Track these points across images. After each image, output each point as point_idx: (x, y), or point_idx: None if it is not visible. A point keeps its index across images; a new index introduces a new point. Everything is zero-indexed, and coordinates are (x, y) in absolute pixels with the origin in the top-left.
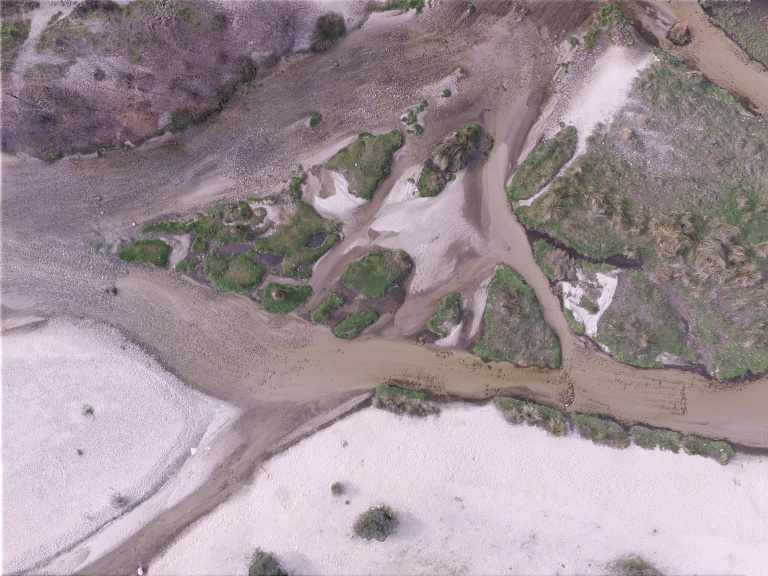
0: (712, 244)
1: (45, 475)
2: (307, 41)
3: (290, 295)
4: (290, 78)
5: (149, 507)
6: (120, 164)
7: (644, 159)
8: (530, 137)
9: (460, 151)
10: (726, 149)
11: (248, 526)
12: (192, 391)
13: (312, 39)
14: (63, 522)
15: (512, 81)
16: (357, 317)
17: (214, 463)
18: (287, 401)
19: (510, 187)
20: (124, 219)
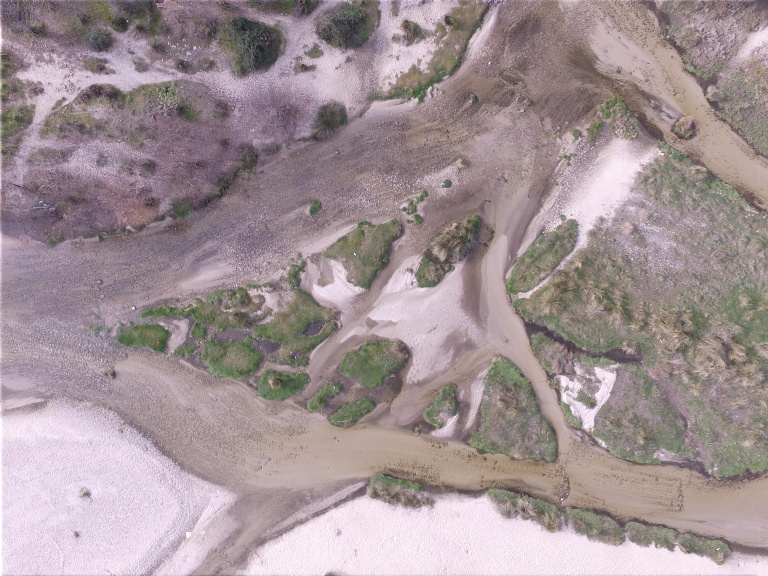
0: (713, 344)
1: (42, 556)
2: (308, 129)
3: (287, 383)
4: (291, 165)
5: None
6: (121, 248)
7: (645, 254)
8: (530, 229)
9: (459, 245)
10: (729, 246)
11: None
12: (188, 475)
13: (313, 128)
14: None
15: (513, 172)
16: (353, 406)
17: (209, 547)
18: (282, 488)
19: (509, 279)
20: (124, 303)
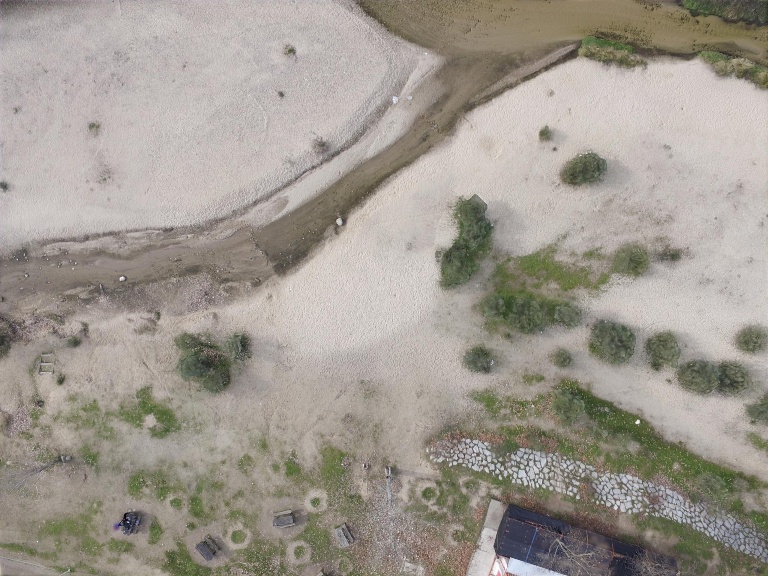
0: None
1: (245, 117)
2: None
3: None
4: None
5: (349, 157)
6: None
7: None
8: None
9: None
10: None
11: (451, 175)
12: (395, 37)
13: None
14: (263, 166)
15: None
16: None
17: (416, 113)
18: (492, 51)
19: None
20: None
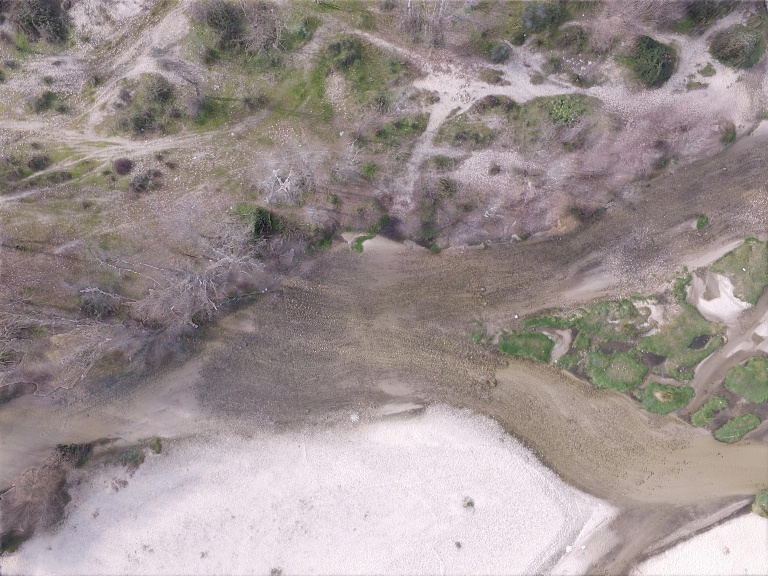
0: None
1: (422, 566)
2: (698, 145)
3: None
4: (677, 180)
5: None
6: (505, 256)
7: None
8: None
9: None
10: None
11: None
12: (570, 488)
13: (705, 144)
14: None
15: None
16: (740, 422)
17: (589, 562)
18: (665, 503)
19: None
20: (506, 311)
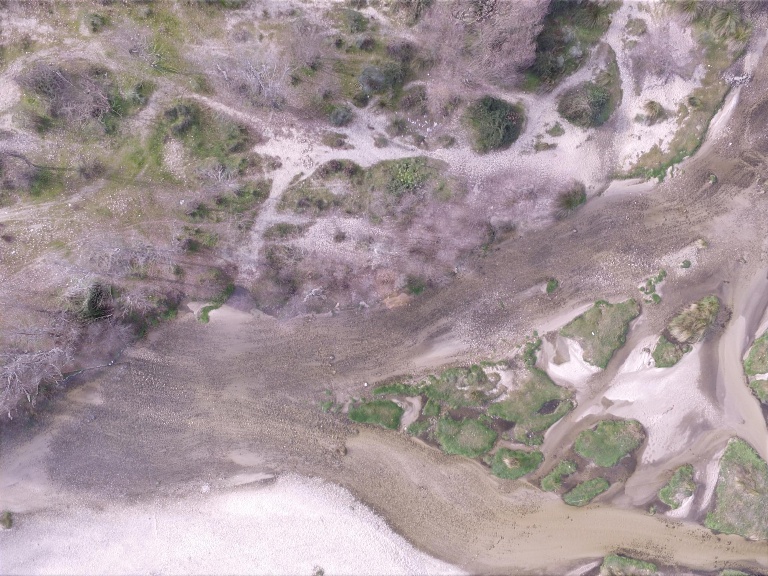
0: None
1: None
2: (547, 208)
3: (522, 462)
4: (527, 243)
5: None
6: (353, 324)
7: None
8: None
9: (704, 327)
10: None
11: None
12: (420, 554)
13: (553, 206)
14: None
15: (752, 254)
16: (588, 486)
17: None
18: (514, 567)
19: (747, 360)
20: (356, 379)
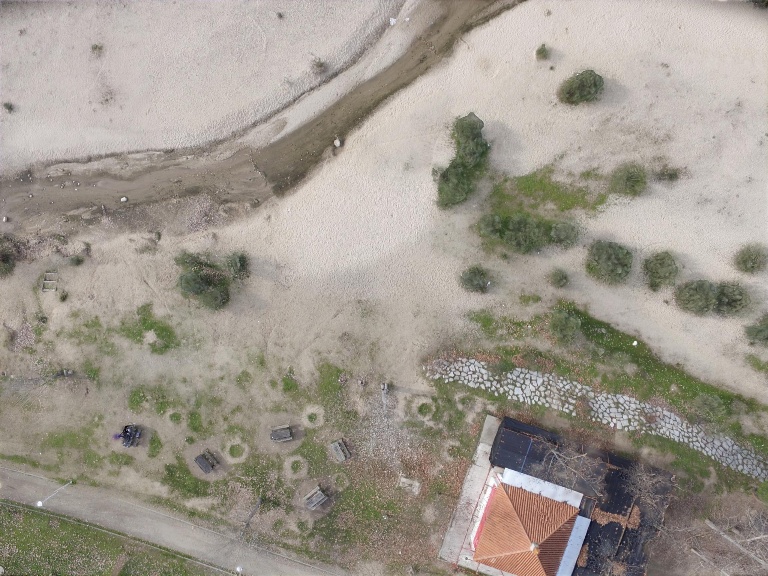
0: None
1: (244, 38)
2: None
3: None
4: None
5: (347, 78)
6: None
7: None
8: None
9: None
10: None
11: (448, 95)
12: None
13: None
14: (262, 87)
15: None
16: None
17: (413, 35)
18: None
19: None
20: None
